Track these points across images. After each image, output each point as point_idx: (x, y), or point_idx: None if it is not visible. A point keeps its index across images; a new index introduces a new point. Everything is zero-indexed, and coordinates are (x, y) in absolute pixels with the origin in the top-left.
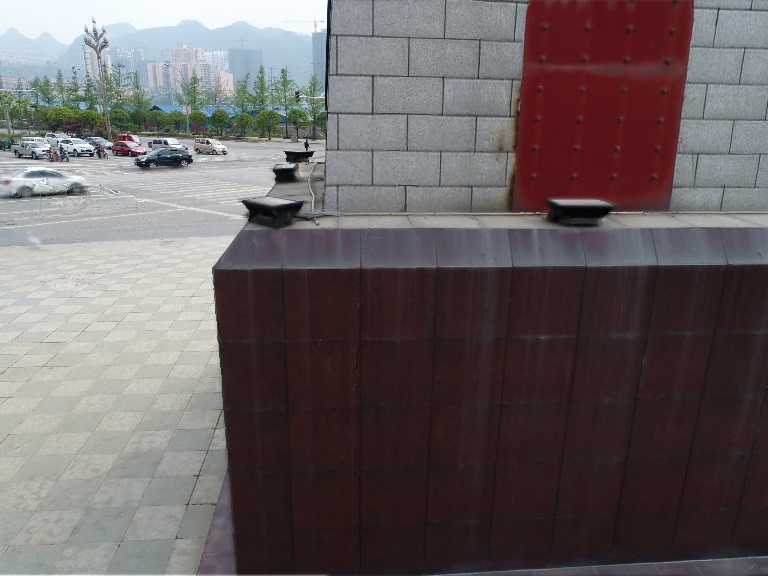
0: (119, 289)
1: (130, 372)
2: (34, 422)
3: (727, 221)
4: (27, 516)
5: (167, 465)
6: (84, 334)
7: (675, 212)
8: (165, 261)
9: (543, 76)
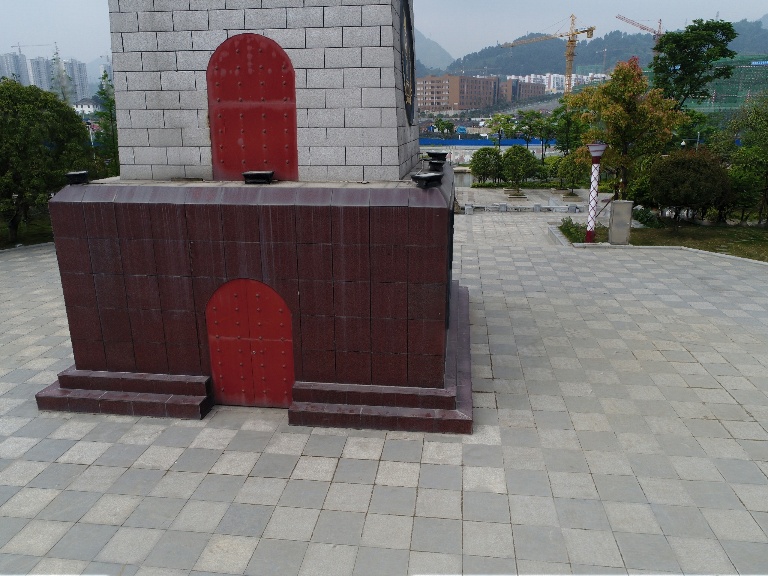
0: None
1: (608, 404)
2: (632, 366)
3: None
4: (564, 326)
5: (510, 339)
6: (760, 477)
7: None
8: None
9: None
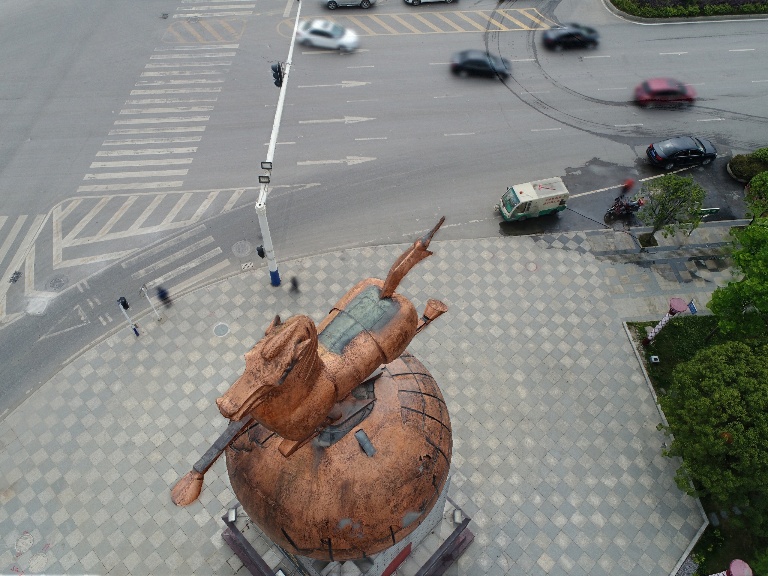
0: (78, 542)
1: None
2: None
3: (424, 554)
4: None
5: None
6: None
7: (412, 554)
8: (49, 480)
9: (384, 575)
